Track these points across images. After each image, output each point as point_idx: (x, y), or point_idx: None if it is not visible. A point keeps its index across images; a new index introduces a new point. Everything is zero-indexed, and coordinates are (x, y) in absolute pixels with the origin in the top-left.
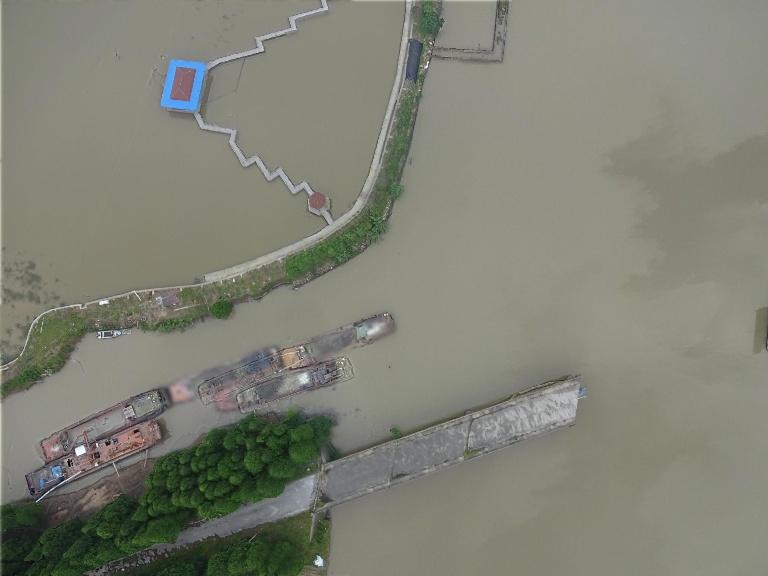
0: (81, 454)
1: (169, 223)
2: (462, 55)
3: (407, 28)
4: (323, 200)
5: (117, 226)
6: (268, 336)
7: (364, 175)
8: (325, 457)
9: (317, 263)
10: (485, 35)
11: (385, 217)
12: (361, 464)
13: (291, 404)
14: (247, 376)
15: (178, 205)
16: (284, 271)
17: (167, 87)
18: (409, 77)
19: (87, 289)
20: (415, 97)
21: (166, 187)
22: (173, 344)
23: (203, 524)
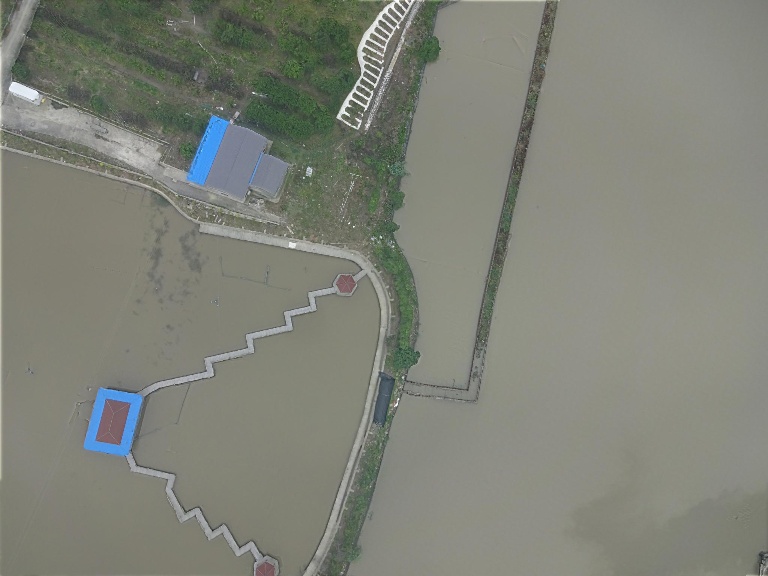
0: None
1: None
2: (435, 391)
3: (379, 358)
4: (272, 574)
5: None
6: None
7: (319, 533)
8: None
9: None
10: (461, 368)
11: None
12: None
13: None
14: None
15: (98, 568)
16: None
17: (93, 424)
18: (377, 424)
19: None
20: (381, 442)
21: (85, 546)
22: None
23: None
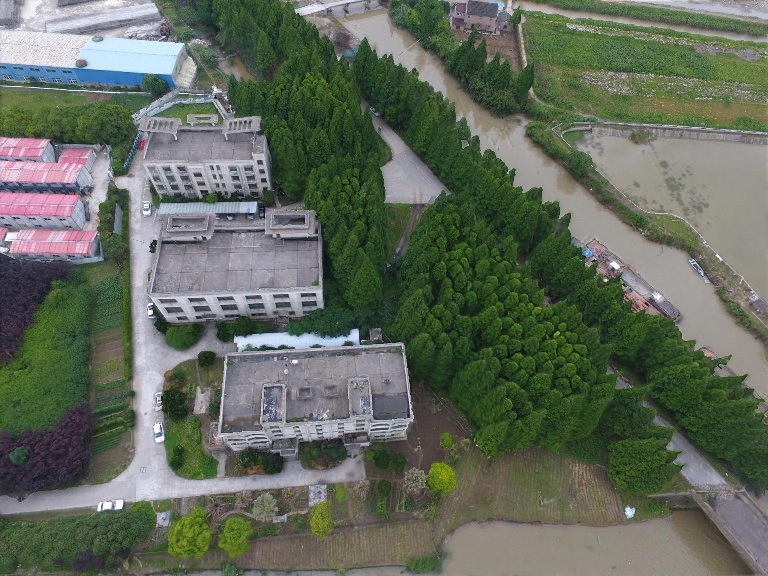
0: (610, 267)
1: None
2: None
3: None
4: None
5: None
6: None
7: None
8: None
9: None
10: None
11: None
12: None
13: None
14: None
15: None
16: None
17: None
18: None
19: (714, 245)
20: None
21: None
22: (721, 318)
23: (620, 378)
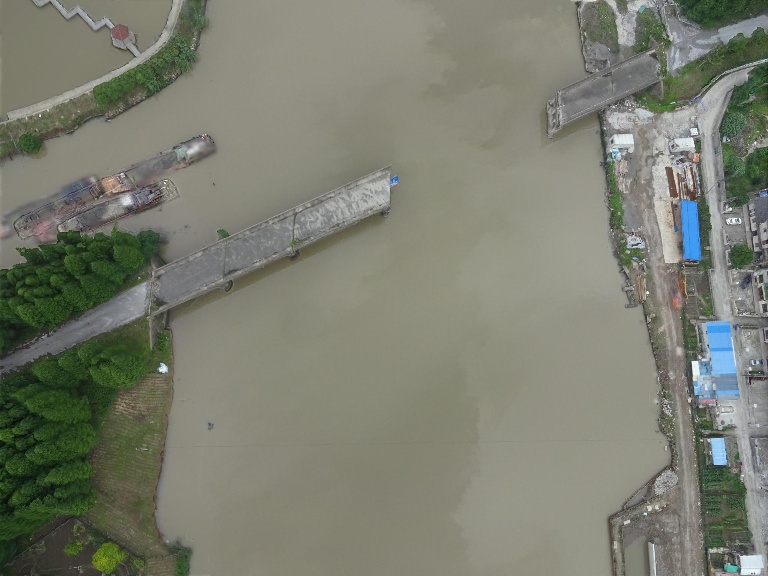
0: None
1: None
2: None
3: None
4: (126, 31)
5: None
6: (84, 167)
7: (167, 10)
8: (156, 267)
9: (127, 91)
10: None
11: (193, 47)
12: (192, 266)
13: (117, 229)
14: (66, 207)
15: None
16: (94, 103)
17: None
18: None
19: None
20: None
21: None
22: None
23: (33, 345)
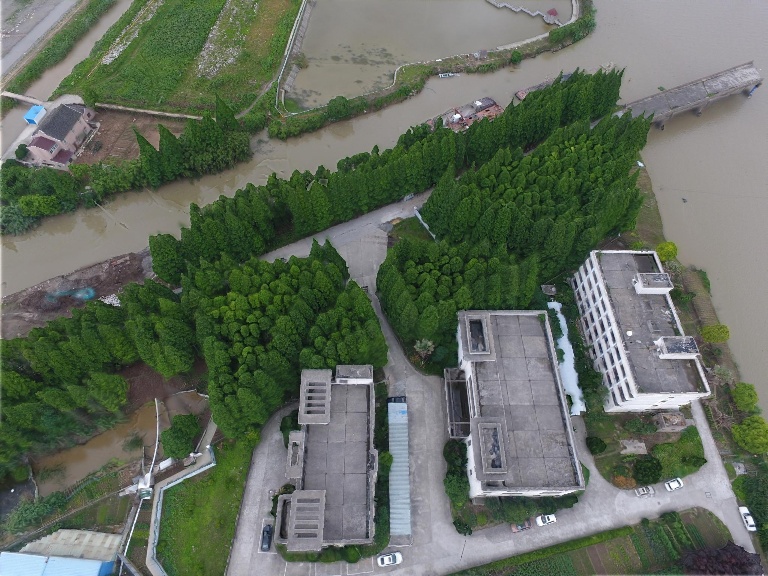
0: (456, 120)
1: (465, 28)
2: None
3: None
4: None
5: (437, 26)
6: (549, 70)
7: (569, 9)
8: None
9: None
10: None
11: None
12: (648, 104)
13: None
14: None
15: (467, 23)
16: (545, 43)
17: None
18: None
19: None
20: None
21: None
22: (489, 79)
23: None
